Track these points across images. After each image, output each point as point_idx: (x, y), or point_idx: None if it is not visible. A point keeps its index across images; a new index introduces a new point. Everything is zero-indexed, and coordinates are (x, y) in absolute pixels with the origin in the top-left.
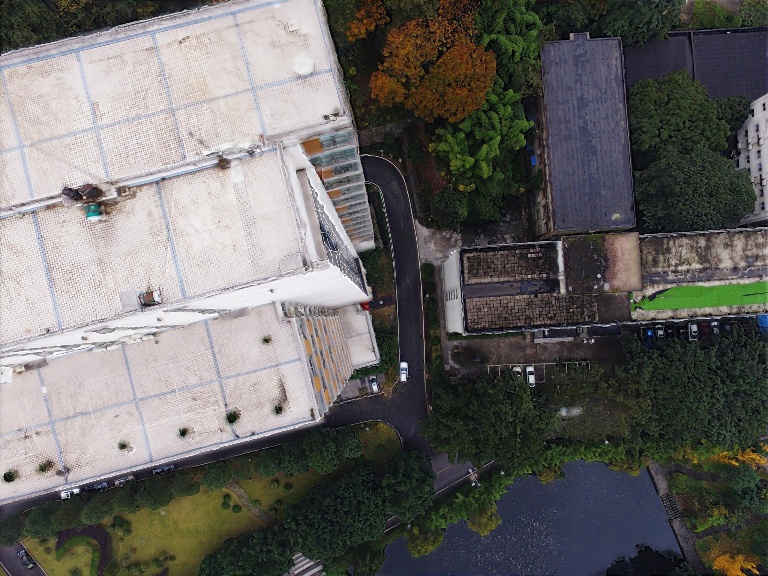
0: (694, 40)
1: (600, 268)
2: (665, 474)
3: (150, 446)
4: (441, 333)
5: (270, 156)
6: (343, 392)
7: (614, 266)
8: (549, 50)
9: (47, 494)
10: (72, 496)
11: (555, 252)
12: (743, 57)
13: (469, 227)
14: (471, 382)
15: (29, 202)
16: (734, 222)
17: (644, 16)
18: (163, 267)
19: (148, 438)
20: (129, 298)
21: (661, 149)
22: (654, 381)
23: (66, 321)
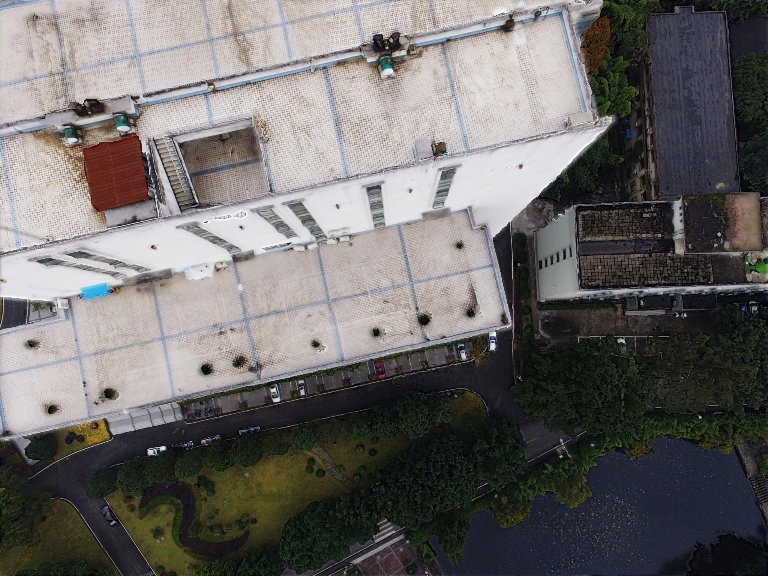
0: None
1: (720, 227)
2: (755, 456)
3: (342, 346)
4: (532, 302)
5: (552, 20)
6: (430, 359)
7: (734, 225)
8: (654, 22)
9: (133, 450)
10: (161, 452)
11: (670, 212)
12: None
13: (562, 198)
14: None
15: (328, 54)
16: None
17: None
18: (448, 123)
19: (340, 338)
20: (424, 145)
21: (765, 121)
22: (761, 350)
23: (353, 171)
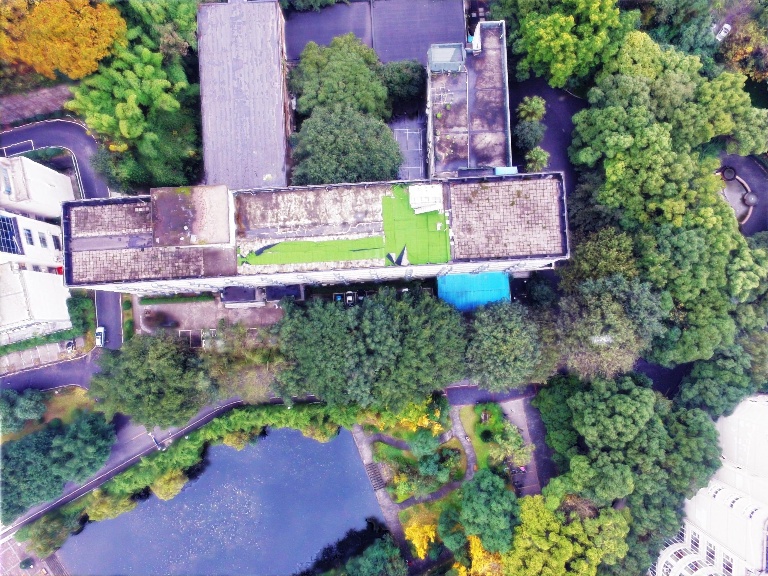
0: (375, 5)
1: (187, 220)
2: (369, 444)
3: None
4: (133, 297)
5: None
6: (42, 356)
7: (202, 218)
8: (206, 12)
9: None
10: None
11: None
12: (423, 22)
13: None
14: None
15: None
16: None
17: None
18: None
19: None
20: None
21: None
22: (293, 341)
23: None
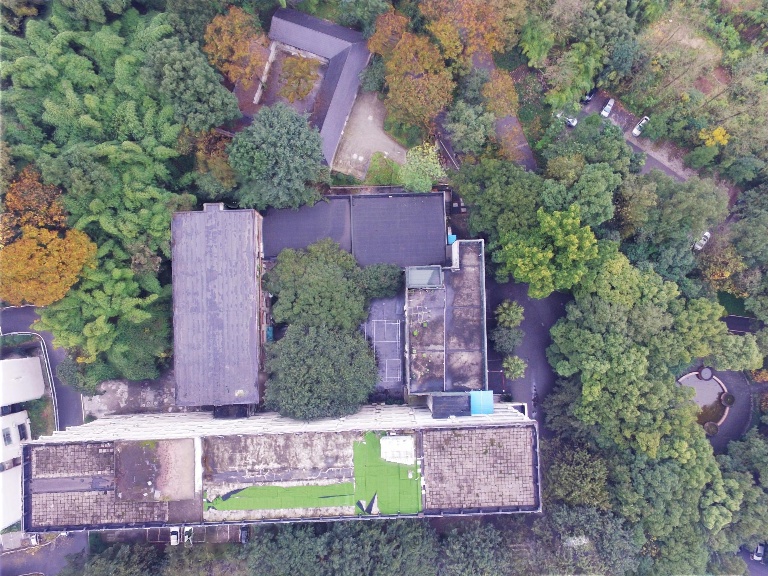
0: (355, 203)
1: (152, 475)
2: None
3: None
4: None
5: None
6: (5, 543)
7: (166, 473)
8: (181, 220)
9: None
10: None
11: None
12: (403, 222)
13: None
14: (127, 541)
15: None
16: (354, 404)
17: (266, 194)
18: None
19: None
20: None
21: (294, 322)
22: (261, 568)
23: None
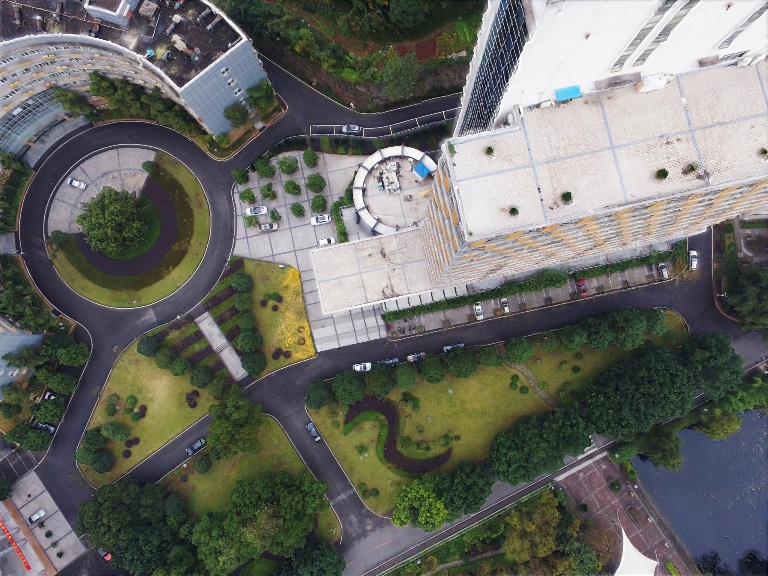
0: None
1: None
2: None
3: None
4: (733, 221)
5: None
6: None
7: None
8: None
9: (338, 367)
10: (373, 365)
11: None
12: None
13: None
14: None
15: None
16: None
17: None
18: None
19: None
20: None
21: None
22: None
23: None
